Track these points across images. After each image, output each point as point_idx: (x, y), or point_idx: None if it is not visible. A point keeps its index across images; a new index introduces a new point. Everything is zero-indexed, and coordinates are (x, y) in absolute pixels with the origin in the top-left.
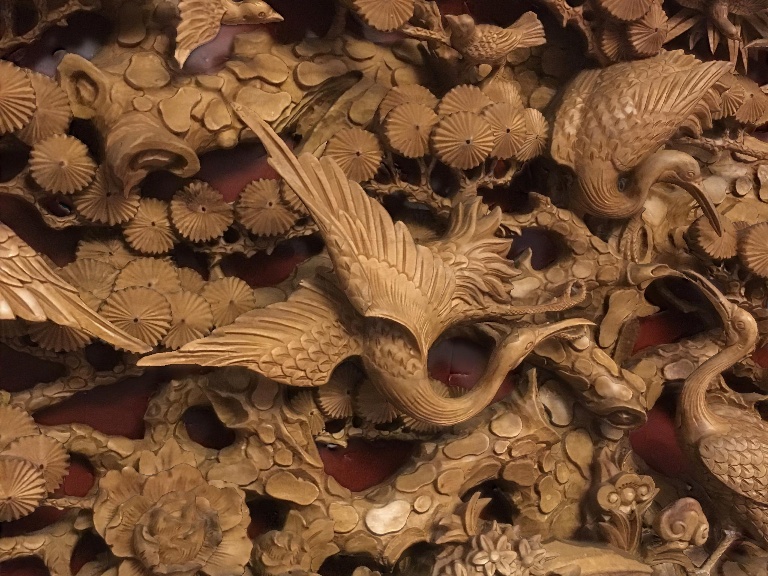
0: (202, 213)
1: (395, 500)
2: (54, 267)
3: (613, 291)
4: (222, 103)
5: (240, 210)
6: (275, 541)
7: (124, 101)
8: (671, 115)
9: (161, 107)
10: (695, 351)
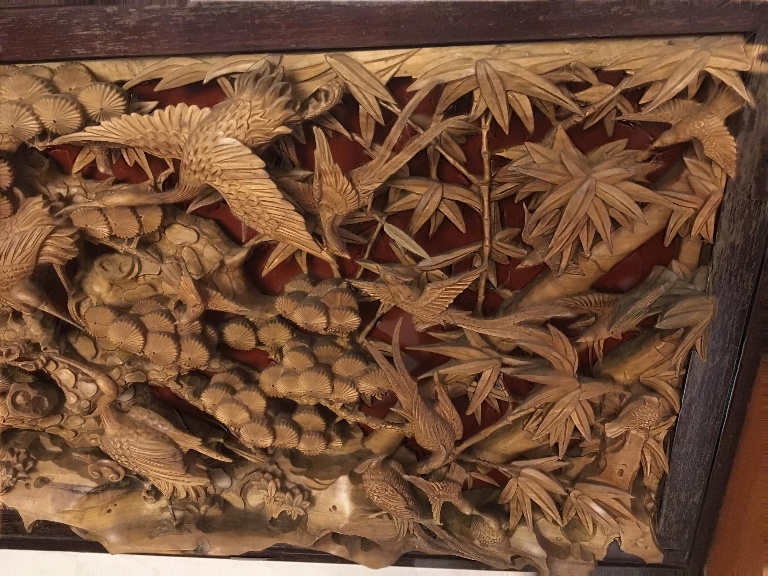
0: None
1: None
2: None
3: None
4: None
5: None
6: None
7: None
8: (14, 265)
9: None
10: (150, 366)
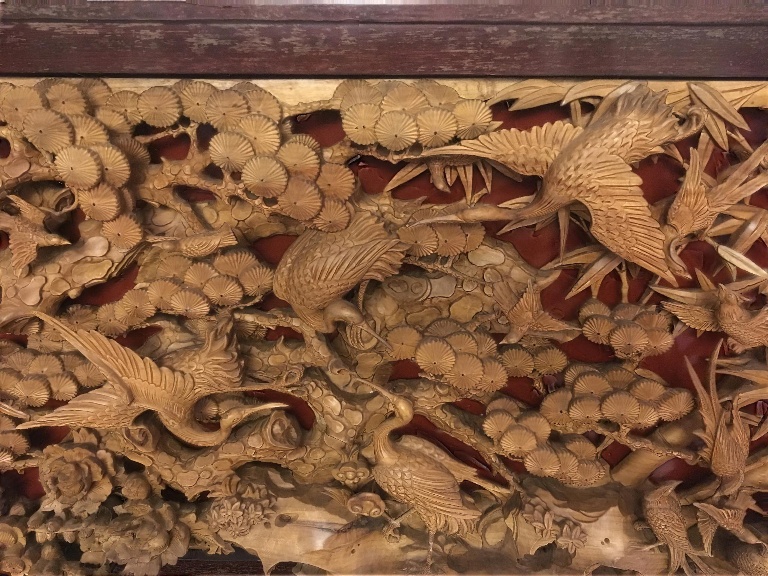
0: (76, 324)
1: (192, 470)
2: (15, 348)
3: (358, 353)
4: (61, 280)
5: (97, 321)
6: (124, 485)
7: (6, 288)
8: (342, 280)
9: (19, 295)
10: (418, 393)
